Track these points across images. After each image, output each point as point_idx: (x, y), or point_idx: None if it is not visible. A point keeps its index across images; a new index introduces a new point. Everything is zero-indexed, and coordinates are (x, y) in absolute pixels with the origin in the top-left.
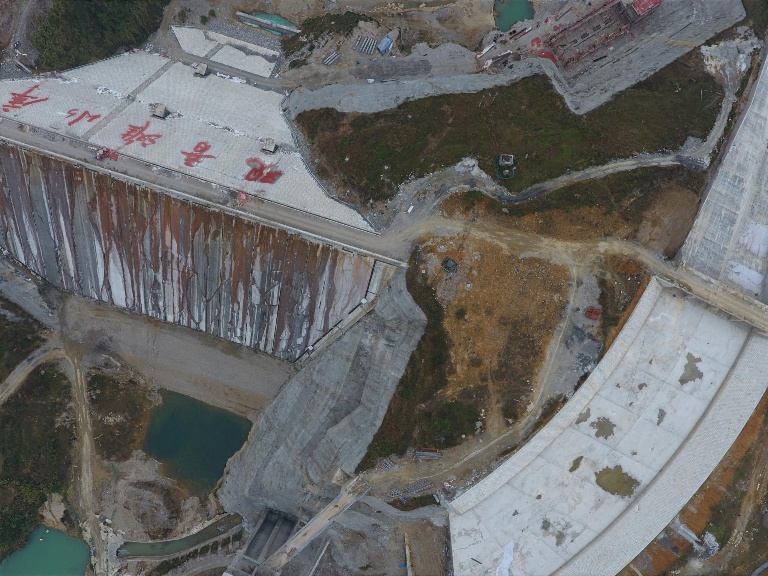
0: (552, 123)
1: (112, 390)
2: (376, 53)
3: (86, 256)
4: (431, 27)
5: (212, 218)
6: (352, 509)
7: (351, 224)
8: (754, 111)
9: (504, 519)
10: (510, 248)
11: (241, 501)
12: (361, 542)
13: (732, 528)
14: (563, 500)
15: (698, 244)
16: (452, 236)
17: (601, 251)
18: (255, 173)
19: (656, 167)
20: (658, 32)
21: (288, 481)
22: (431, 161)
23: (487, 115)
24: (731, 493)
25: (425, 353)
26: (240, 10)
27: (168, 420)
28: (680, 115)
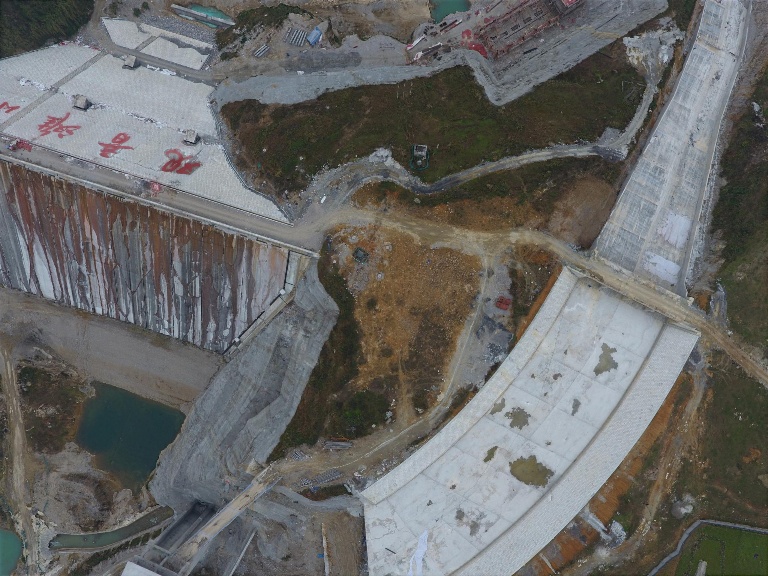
0: (470, 114)
1: (44, 382)
2: (306, 45)
3: (11, 248)
4: (366, 20)
5: (127, 209)
6: (269, 499)
7: (264, 215)
8: (678, 102)
9: (418, 509)
10: (421, 238)
11: (169, 493)
12: (283, 533)
13: (640, 517)
14: (477, 490)
15: (615, 235)
16: (364, 226)
17: (512, 241)
18: (172, 164)
19: (572, 158)
20: (587, 24)
21: (208, 472)
22: (345, 152)
23: (405, 106)
24: (639, 482)
25: (337, 343)
26: (175, 3)
27: (102, 413)
28: (600, 106)
